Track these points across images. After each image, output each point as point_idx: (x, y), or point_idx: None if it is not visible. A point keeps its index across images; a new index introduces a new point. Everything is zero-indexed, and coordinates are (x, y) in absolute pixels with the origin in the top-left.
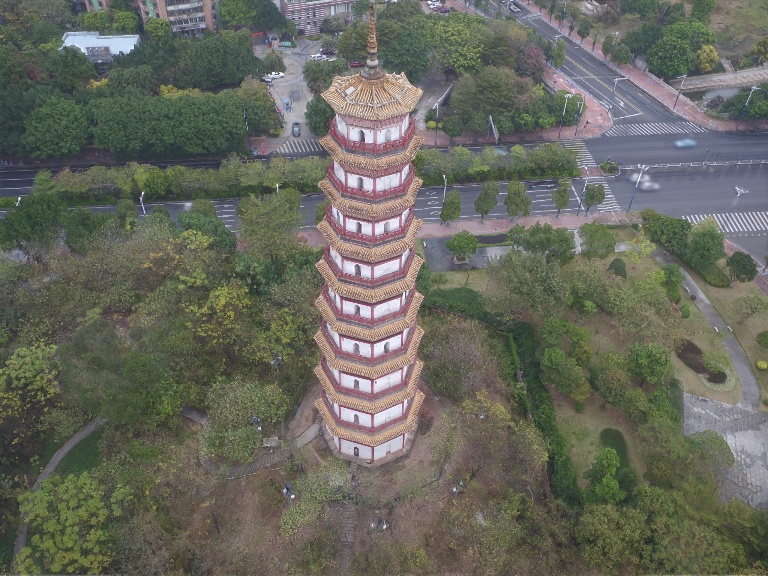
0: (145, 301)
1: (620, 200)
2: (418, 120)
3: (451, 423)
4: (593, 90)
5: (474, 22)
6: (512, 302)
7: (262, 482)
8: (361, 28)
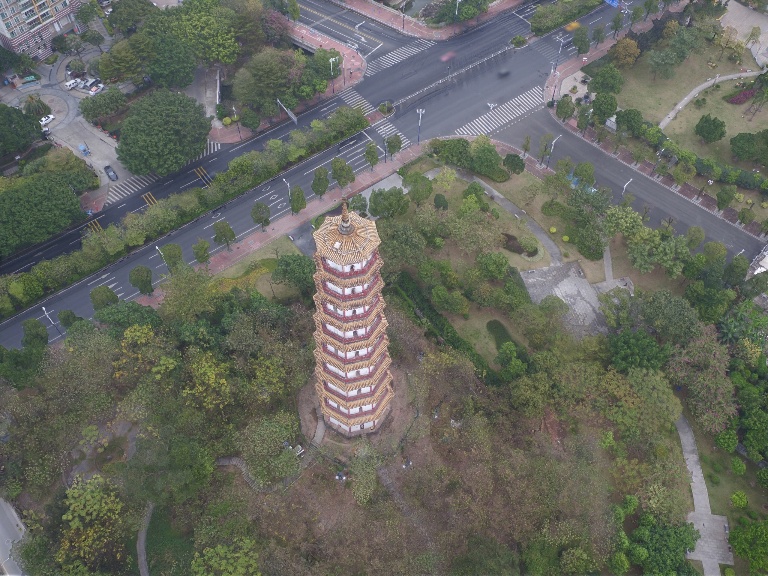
0: (118, 398)
1: (408, 135)
2: (212, 120)
3: (424, 382)
4: (334, 33)
5: (212, 6)
6: (393, 266)
7: (309, 479)
8: (117, 52)
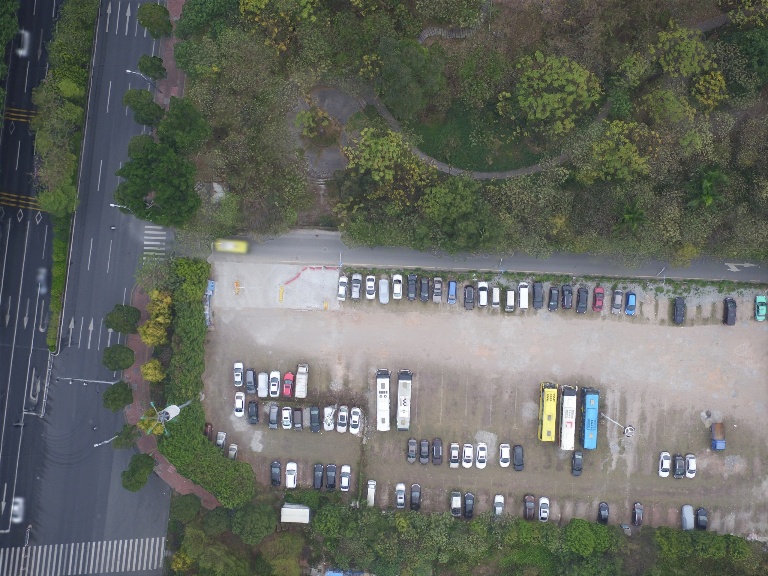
0: None
1: None
2: None
3: None
4: None
5: None
6: None
7: None
8: None
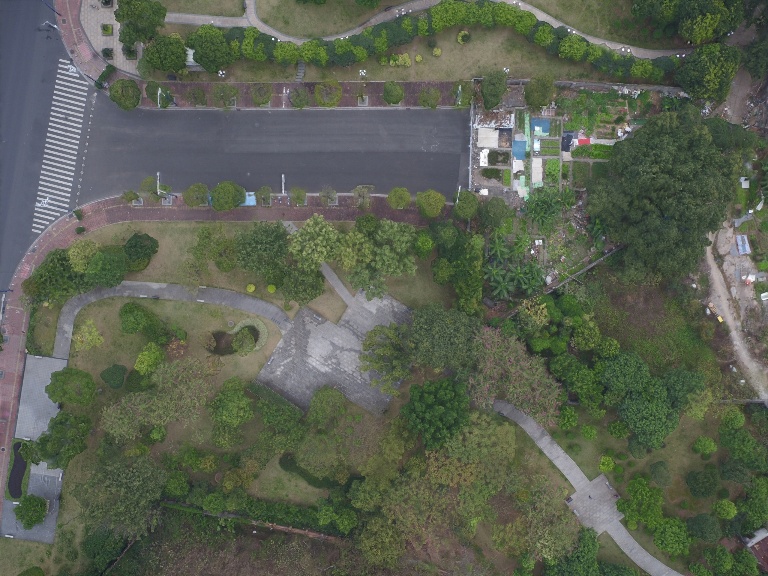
0: None
1: None
2: None
3: None
4: None
5: None
6: None
7: None
8: None
